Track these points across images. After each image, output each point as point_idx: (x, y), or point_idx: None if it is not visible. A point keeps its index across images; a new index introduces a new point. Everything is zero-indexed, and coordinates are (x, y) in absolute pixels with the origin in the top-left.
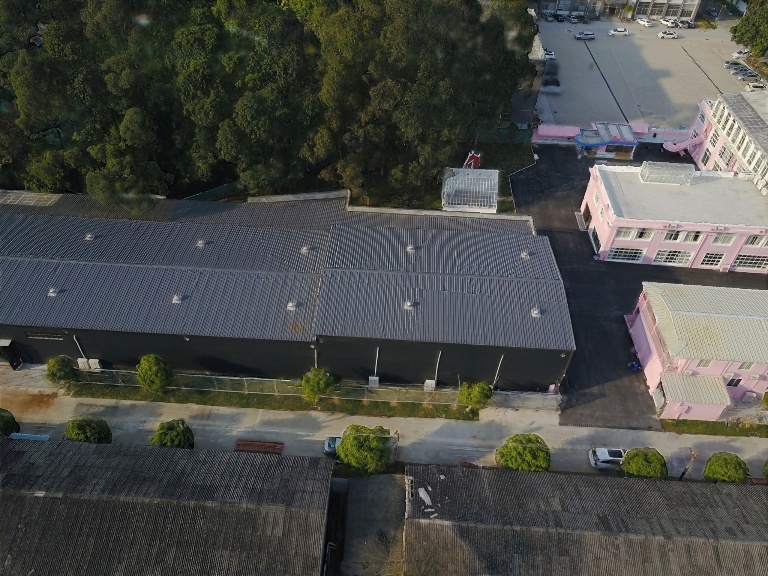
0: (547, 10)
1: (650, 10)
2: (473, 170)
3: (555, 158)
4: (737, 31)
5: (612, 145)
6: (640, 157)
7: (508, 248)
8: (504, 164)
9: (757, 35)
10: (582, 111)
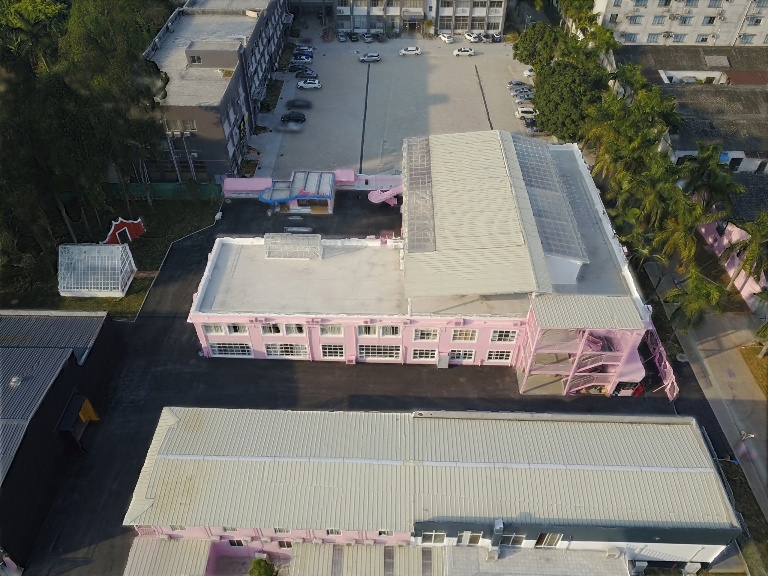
0: (343, 29)
1: (453, 24)
2: (90, 247)
3: (241, 216)
4: (518, 48)
5: (303, 199)
6: (342, 210)
7: (4, 371)
8: (177, 227)
9: (535, 52)
10: (314, 152)
